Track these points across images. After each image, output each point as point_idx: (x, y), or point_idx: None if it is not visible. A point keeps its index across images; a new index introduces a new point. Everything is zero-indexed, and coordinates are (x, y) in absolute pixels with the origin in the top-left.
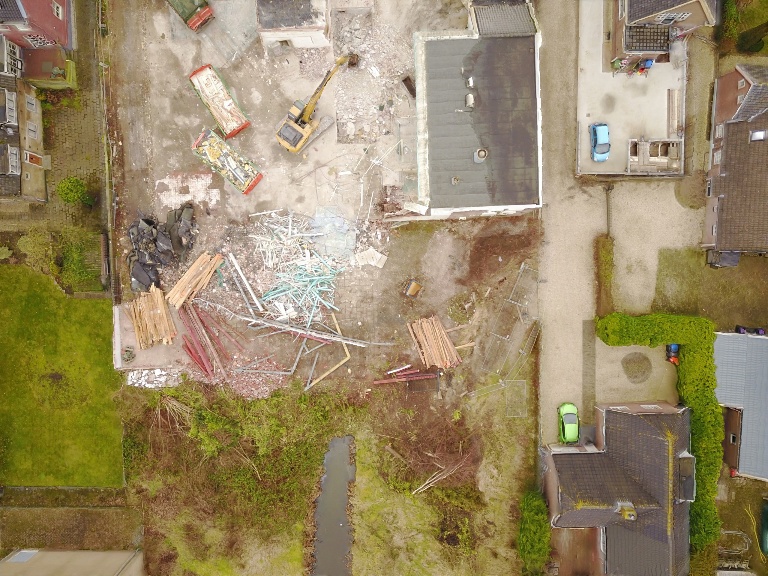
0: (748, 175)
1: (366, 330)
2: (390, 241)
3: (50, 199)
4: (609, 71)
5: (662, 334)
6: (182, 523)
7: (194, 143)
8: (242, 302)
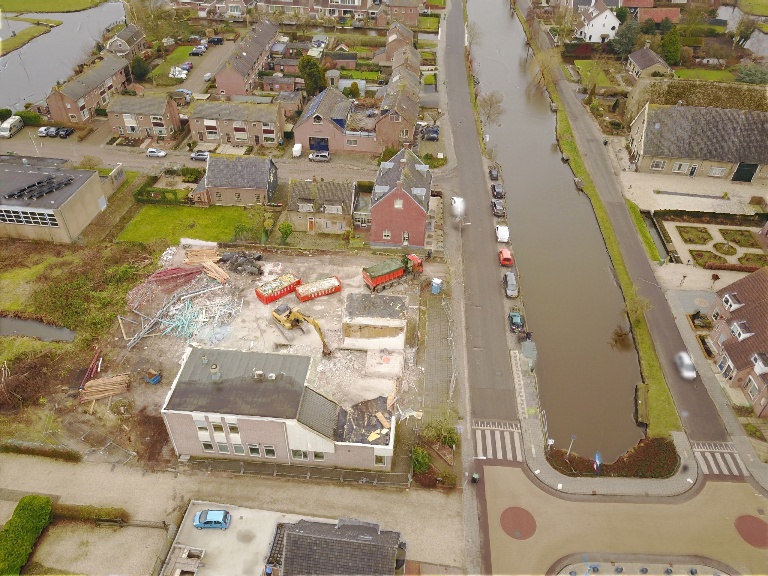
0: None
1: (139, 350)
2: None
3: None
4: None
5: (5, 540)
6: (75, 261)
7: None
8: None
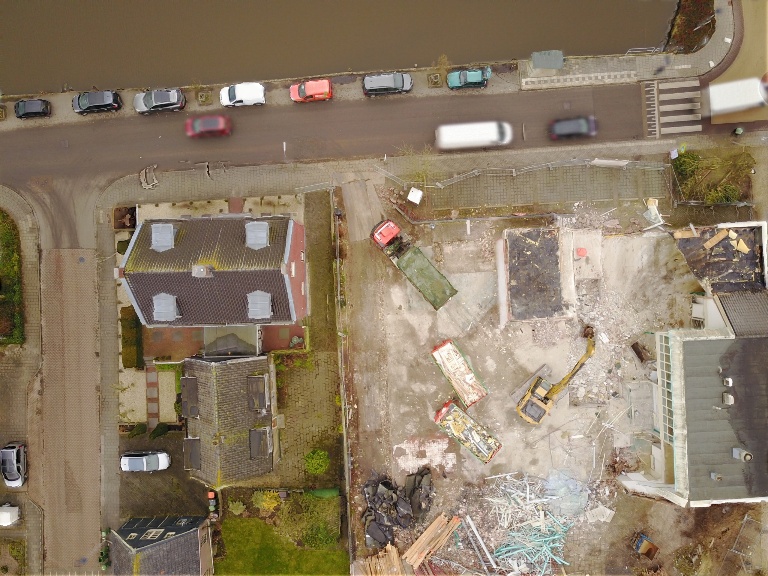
0: None
1: None
2: (617, 496)
3: (283, 456)
4: None
5: None
6: None
7: (438, 417)
8: (475, 558)
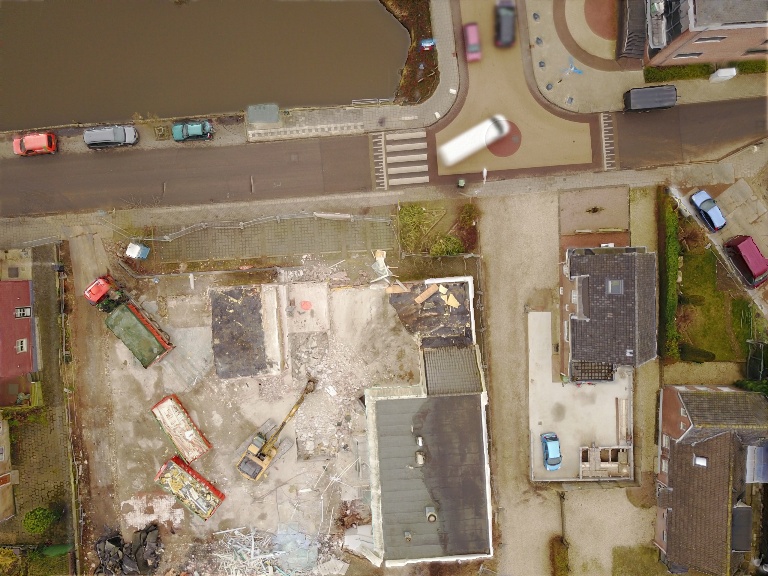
0: (694, 496)
1: None
2: None
3: (18, 512)
4: (559, 381)
5: None
6: None
7: (157, 475)
8: None
